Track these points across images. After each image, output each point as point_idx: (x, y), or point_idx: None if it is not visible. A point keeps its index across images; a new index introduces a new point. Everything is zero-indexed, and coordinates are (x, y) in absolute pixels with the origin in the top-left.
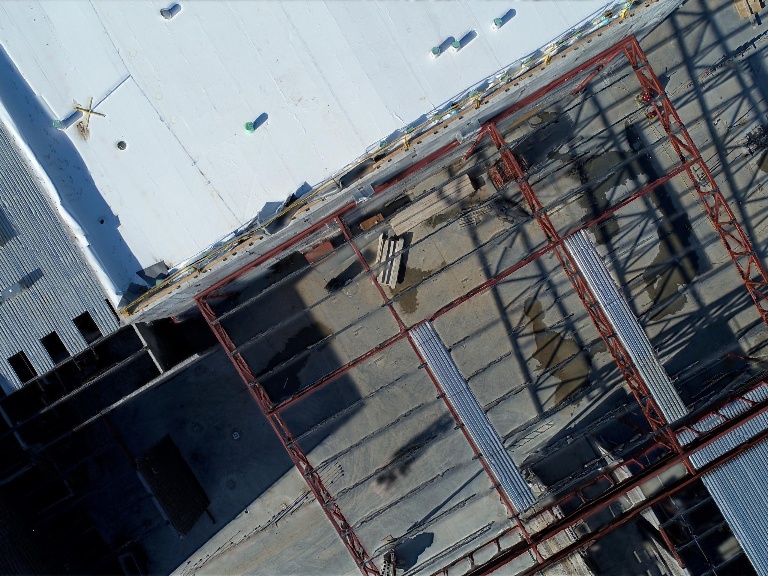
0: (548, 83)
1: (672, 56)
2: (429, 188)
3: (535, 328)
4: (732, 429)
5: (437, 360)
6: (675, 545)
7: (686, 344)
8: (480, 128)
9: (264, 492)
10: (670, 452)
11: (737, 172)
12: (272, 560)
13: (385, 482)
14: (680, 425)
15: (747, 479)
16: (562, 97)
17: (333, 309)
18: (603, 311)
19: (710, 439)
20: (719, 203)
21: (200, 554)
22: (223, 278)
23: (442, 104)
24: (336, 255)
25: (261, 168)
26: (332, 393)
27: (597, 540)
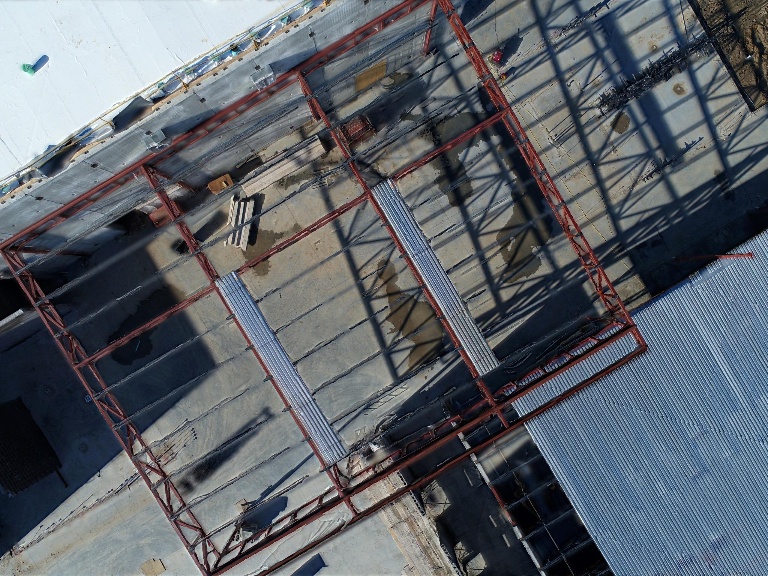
0: (352, 31)
1: (525, 17)
2: (281, 149)
3: (388, 290)
4: (544, 381)
5: (244, 311)
6: (505, 503)
7: (541, 307)
8: (271, 73)
9: (116, 455)
10: (486, 406)
11: (591, 133)
12: (125, 524)
13: (238, 445)
14: (507, 381)
15: (577, 436)
16: (413, 57)
17: (185, 271)
18: (412, 262)
19: (522, 391)
20: (573, 165)
21: (52, 518)
22: (26, 228)
23: (224, 46)
24: (187, 217)
25: (42, 111)
26: (184, 356)
27: (452, 504)
